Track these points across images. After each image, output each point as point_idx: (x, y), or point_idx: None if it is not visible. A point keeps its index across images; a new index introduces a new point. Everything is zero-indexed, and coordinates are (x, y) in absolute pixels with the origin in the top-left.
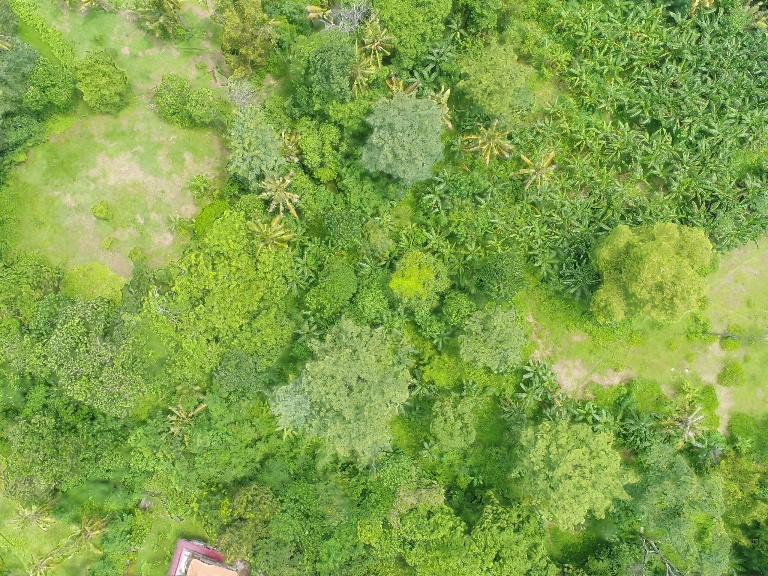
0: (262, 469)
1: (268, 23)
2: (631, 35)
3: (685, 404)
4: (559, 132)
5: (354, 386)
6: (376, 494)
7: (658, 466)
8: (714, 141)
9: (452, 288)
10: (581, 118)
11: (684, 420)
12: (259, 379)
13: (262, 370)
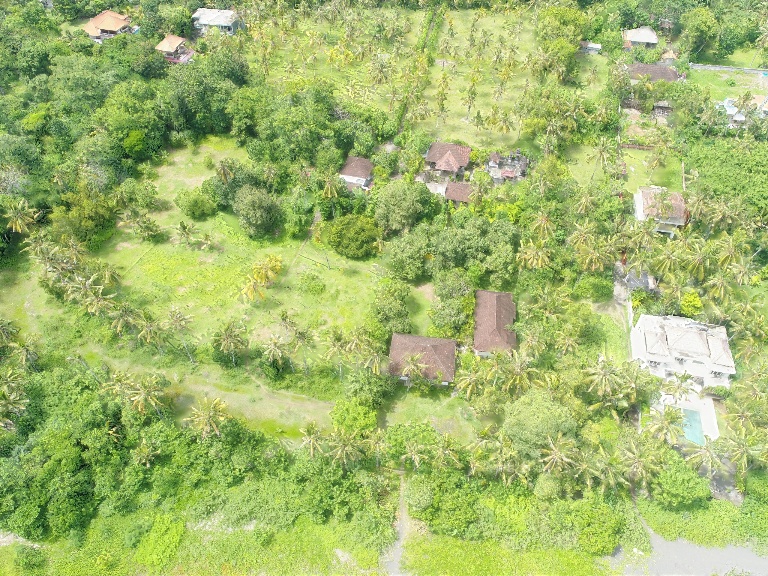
0: None
1: None
2: None
3: None
4: None
5: None
6: None
7: None
8: None
9: None
10: None
11: None
12: None
13: None
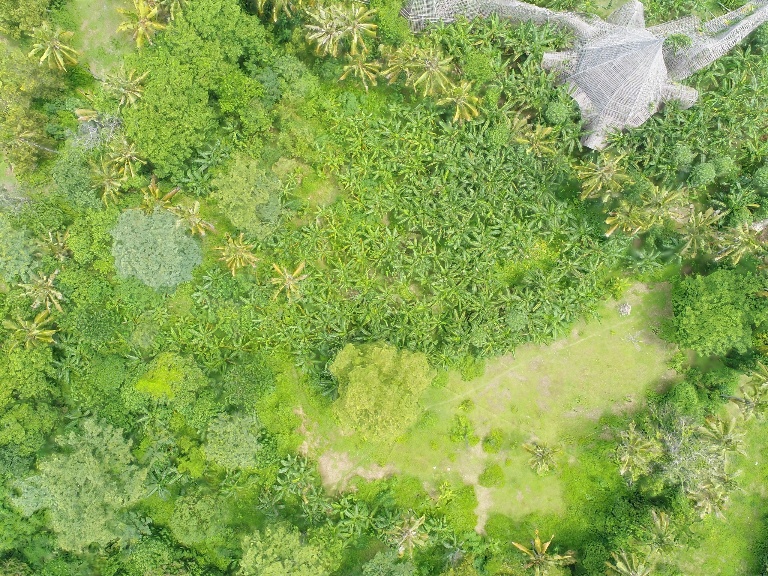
0: (31, 542)
1: (17, 137)
2: (402, 142)
3: (443, 502)
4: (325, 237)
5: (82, 486)
6: (127, 575)
7: (373, 575)
8: (476, 253)
9: (209, 386)
10: (354, 221)
11: (404, 532)
12: (22, 463)
13: (25, 455)
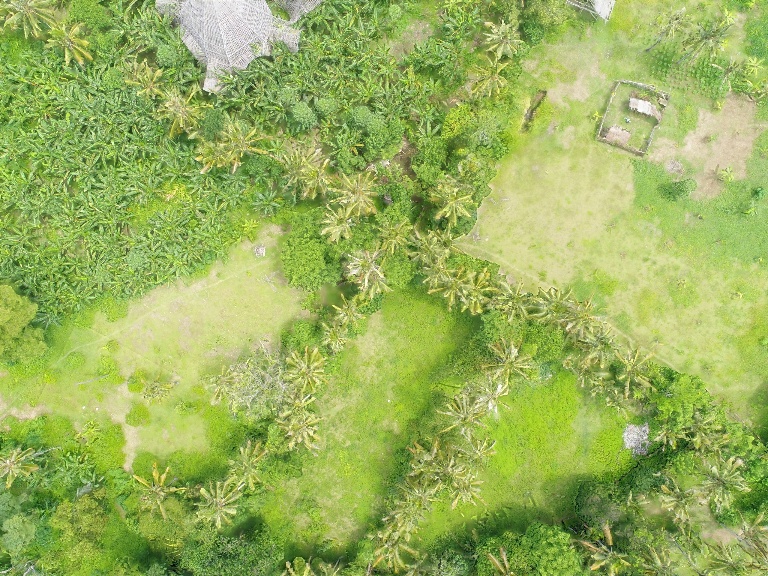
0: None
1: None
2: (33, 87)
3: (91, 441)
4: None
5: None
6: None
7: None
8: None
9: None
10: None
11: None
12: None
13: None
